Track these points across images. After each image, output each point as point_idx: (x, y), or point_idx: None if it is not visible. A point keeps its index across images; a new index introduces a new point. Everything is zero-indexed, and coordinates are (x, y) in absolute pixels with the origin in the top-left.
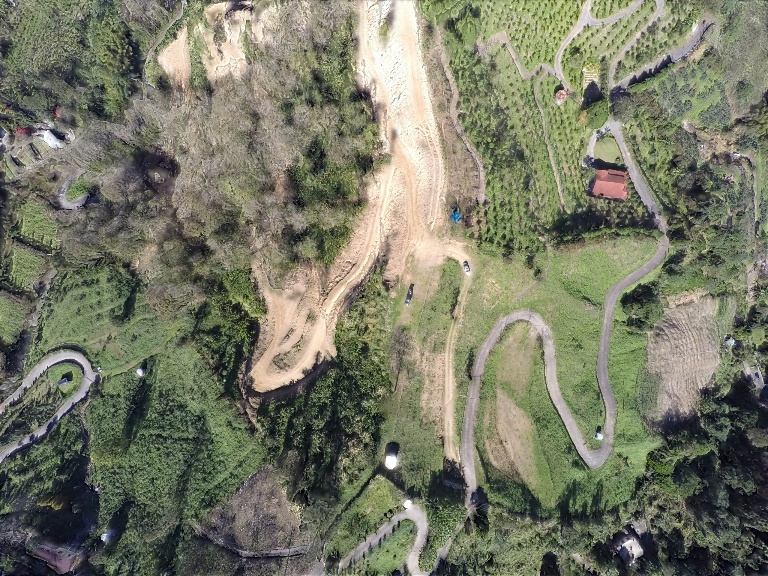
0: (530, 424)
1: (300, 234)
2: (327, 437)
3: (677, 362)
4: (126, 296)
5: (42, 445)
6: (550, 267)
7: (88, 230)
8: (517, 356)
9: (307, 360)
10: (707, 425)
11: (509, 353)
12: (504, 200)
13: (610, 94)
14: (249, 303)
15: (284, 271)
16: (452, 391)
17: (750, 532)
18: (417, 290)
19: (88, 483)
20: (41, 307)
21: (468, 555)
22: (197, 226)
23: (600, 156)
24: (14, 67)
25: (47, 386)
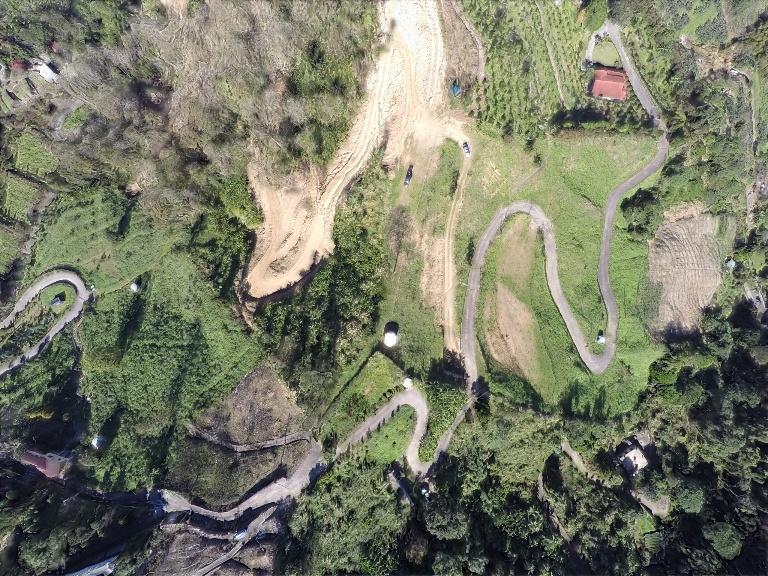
0: (531, 317)
1: None
2: (325, 323)
3: (678, 273)
4: (121, 215)
5: (33, 364)
6: (550, 156)
7: (83, 144)
8: (517, 249)
9: (304, 261)
10: (709, 342)
11: (509, 246)
12: (503, 81)
13: (608, 1)
14: (246, 215)
15: (281, 161)
16: (452, 278)
17: (755, 445)
18: (416, 171)
19: (80, 394)
20: None
21: (469, 448)
22: (194, 135)
23: (599, 60)
24: (11, 8)
25: (39, 308)
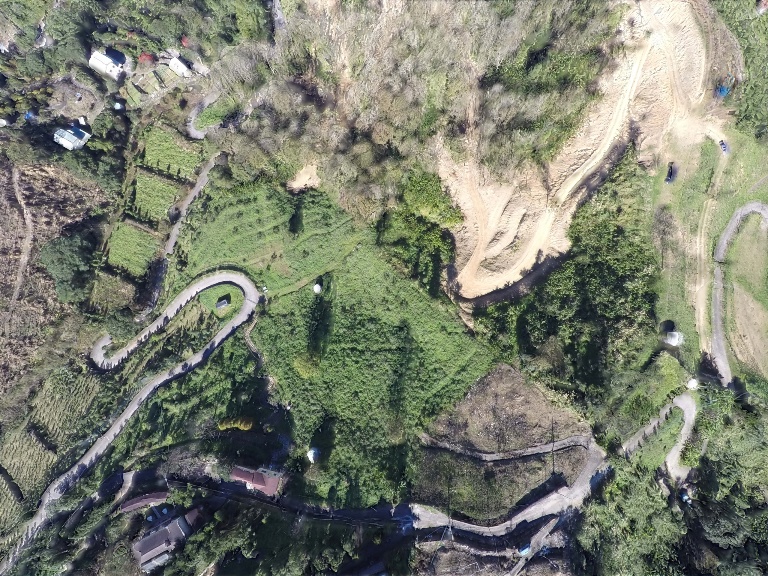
0: None
1: (533, 121)
2: (586, 322)
3: None
4: (291, 213)
5: (203, 371)
6: None
7: (261, 138)
8: (751, 249)
9: (526, 260)
10: None
11: (742, 246)
12: None
13: None
14: (439, 213)
15: None
16: (704, 277)
17: None
18: (676, 168)
19: (273, 403)
20: (183, 231)
21: None
22: (389, 130)
23: None
24: None
25: (198, 312)
